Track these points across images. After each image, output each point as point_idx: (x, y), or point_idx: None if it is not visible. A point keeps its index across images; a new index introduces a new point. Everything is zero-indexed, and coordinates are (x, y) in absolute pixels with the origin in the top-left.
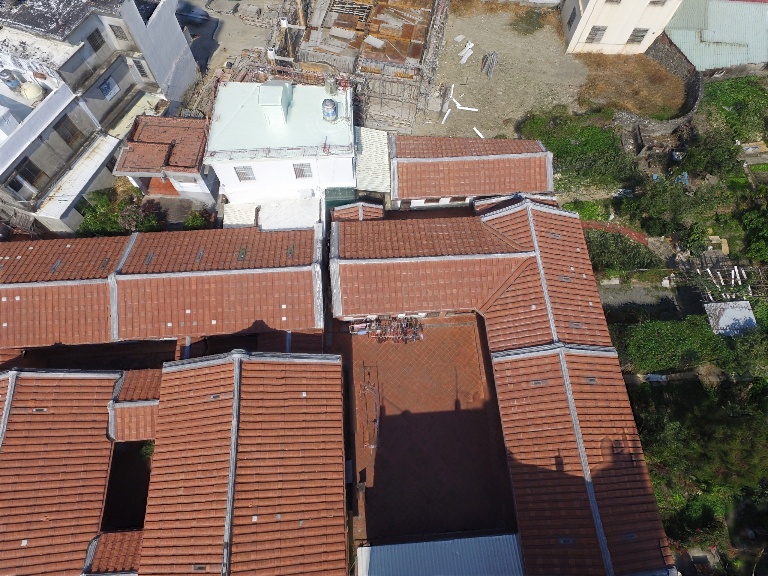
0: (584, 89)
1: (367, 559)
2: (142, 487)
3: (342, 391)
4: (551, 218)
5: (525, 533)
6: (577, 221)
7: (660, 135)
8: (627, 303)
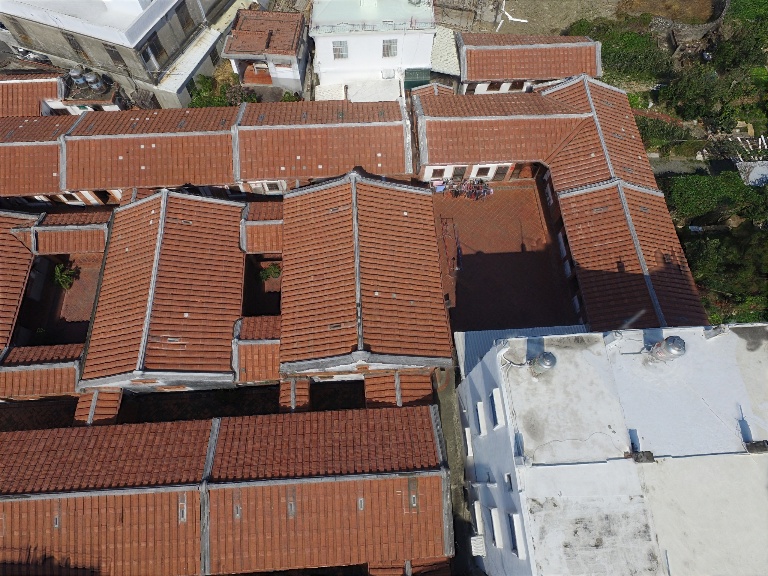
0: (621, 5)
1: (463, 340)
2: (259, 305)
3: (434, 216)
4: (603, 91)
5: (594, 319)
6: (625, 96)
7: (691, 40)
8: (666, 172)
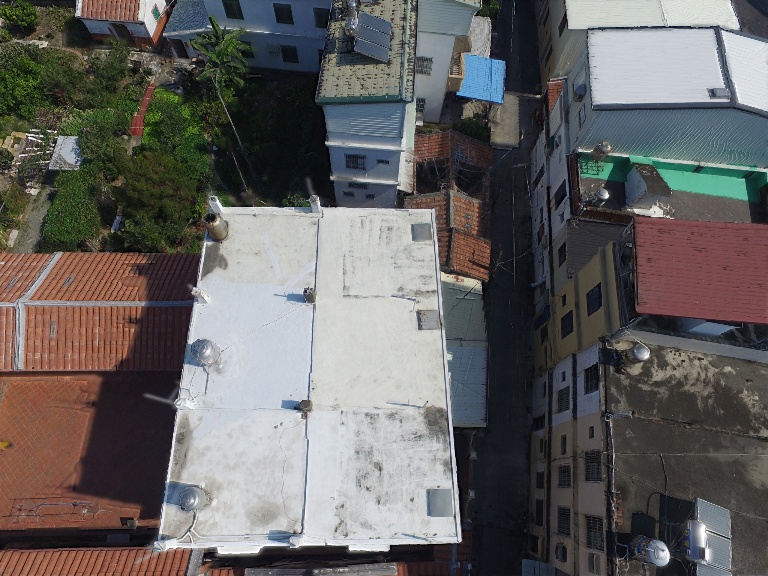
0: None
1: None
2: None
3: None
4: None
5: None
6: None
7: None
8: (40, 229)
